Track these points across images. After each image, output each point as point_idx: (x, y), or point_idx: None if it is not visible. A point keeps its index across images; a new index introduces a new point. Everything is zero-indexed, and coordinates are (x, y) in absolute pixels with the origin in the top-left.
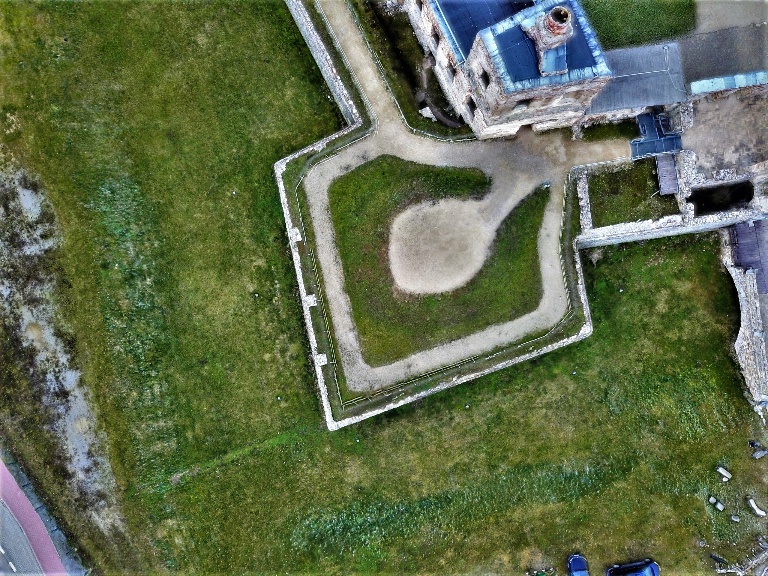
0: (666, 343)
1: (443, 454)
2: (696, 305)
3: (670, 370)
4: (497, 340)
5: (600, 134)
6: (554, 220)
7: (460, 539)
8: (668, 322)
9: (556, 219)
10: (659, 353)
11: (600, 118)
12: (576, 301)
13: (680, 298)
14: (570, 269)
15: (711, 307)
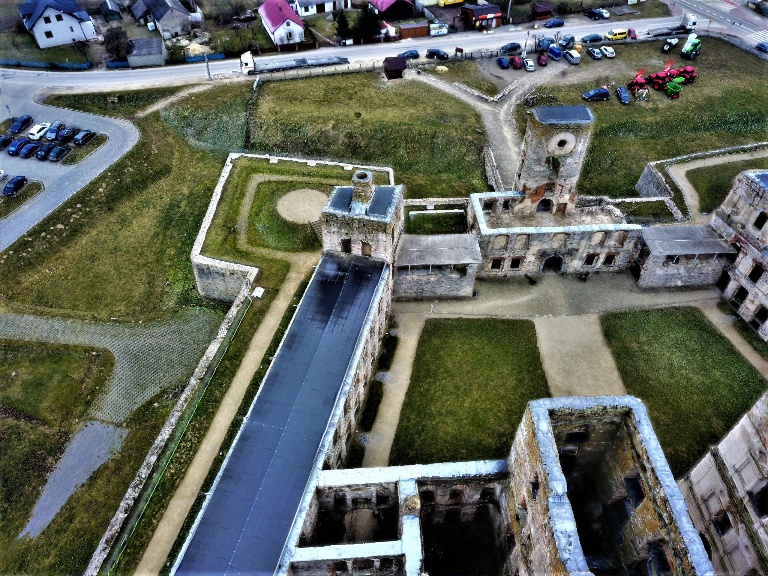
0: None
1: (703, 145)
2: None
3: None
4: (705, 161)
5: None
6: (691, 202)
7: (687, 112)
8: None
9: None
10: (579, 181)
11: None
12: (663, 173)
13: None
14: (672, 184)
15: None
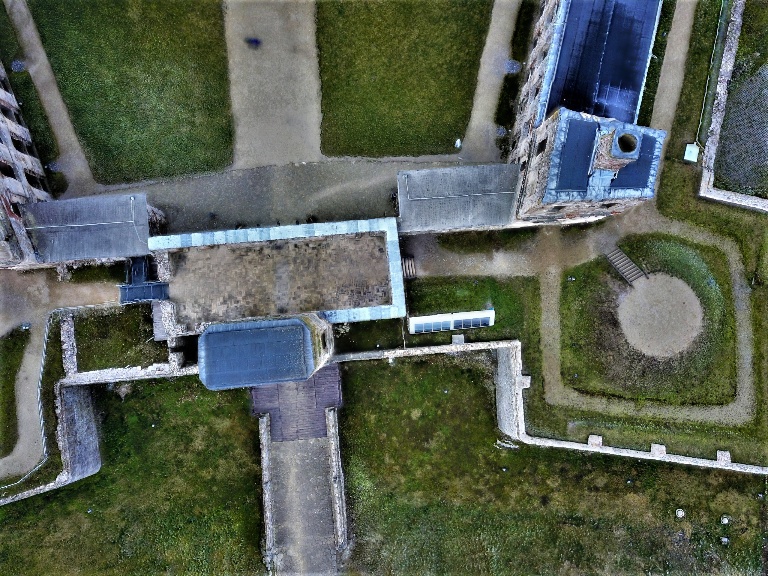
0: (198, 482)
1: None
2: (233, 443)
3: (196, 511)
4: None
5: (90, 276)
6: (34, 363)
7: None
8: (203, 460)
9: (36, 362)
10: (189, 492)
11: (90, 259)
12: (53, 448)
13: (217, 435)
14: (49, 414)
15: (249, 446)
